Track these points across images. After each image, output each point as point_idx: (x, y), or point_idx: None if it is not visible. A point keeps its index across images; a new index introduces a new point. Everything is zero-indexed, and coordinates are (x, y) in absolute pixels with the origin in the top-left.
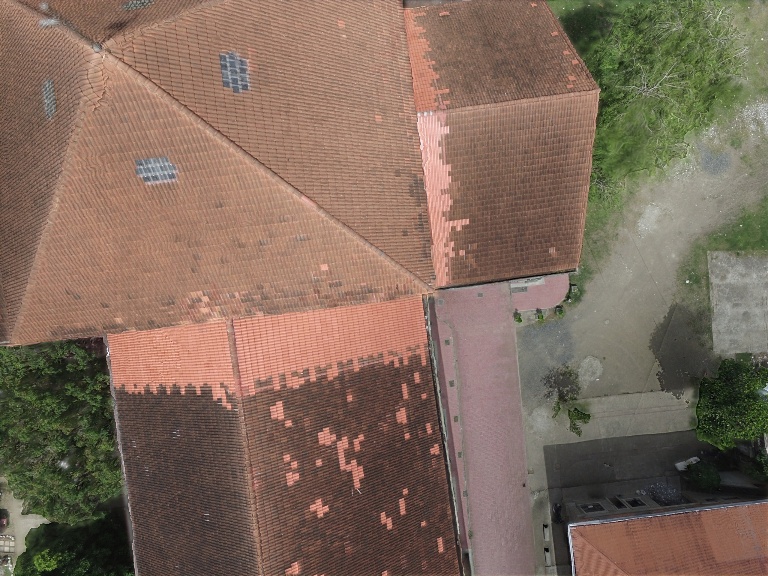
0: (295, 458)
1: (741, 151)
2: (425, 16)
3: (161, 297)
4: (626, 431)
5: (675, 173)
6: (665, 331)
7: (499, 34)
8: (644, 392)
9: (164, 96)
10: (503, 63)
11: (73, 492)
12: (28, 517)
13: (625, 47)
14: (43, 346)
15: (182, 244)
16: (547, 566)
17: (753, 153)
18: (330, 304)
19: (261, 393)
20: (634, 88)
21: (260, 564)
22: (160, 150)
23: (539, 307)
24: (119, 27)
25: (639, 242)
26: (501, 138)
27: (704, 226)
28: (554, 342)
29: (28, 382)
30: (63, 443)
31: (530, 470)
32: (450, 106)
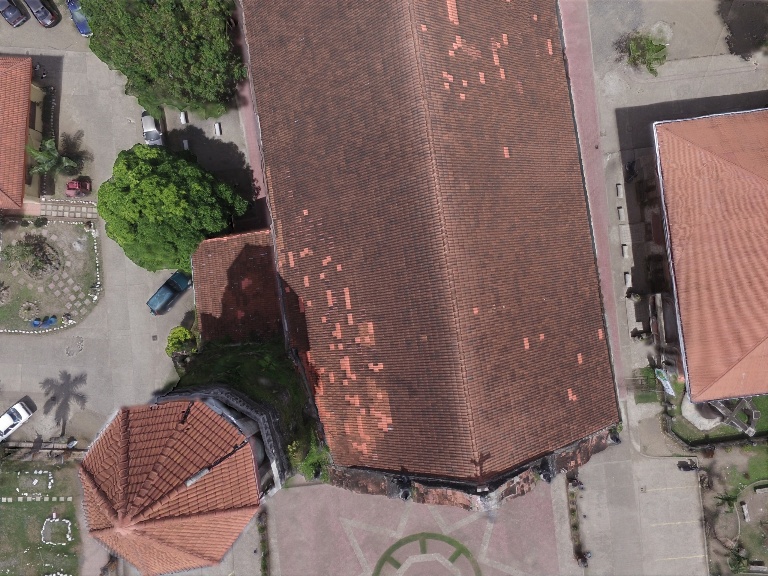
0: None
1: None
2: None
3: None
4: (696, 93)
5: None
6: None
7: None
8: (713, 55)
9: None
10: None
11: (182, 45)
12: None
13: None
14: None
15: None
16: (620, 224)
17: None
18: None
19: None
20: None
21: None
22: None
23: None
24: None
25: None
26: None
27: None
28: (625, 8)
29: None
30: None
31: (603, 132)
32: None
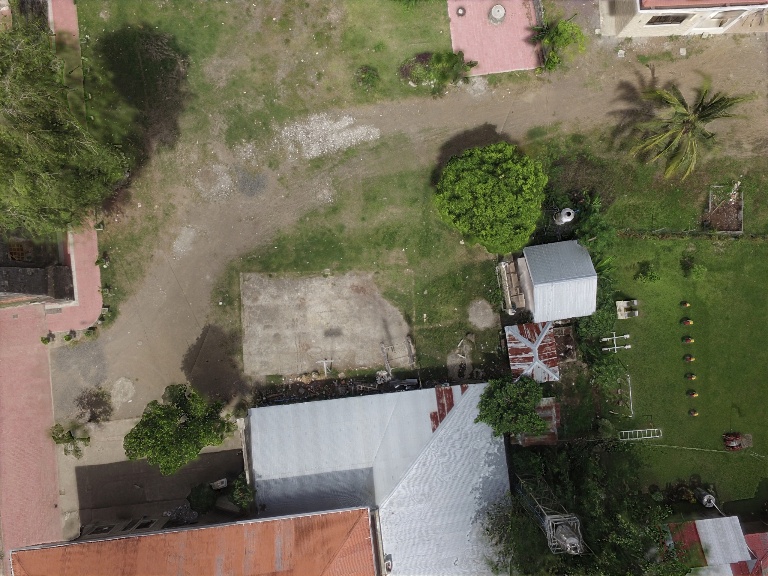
0: None
1: (278, 173)
2: None
3: None
4: None
5: (212, 195)
6: (198, 353)
7: None
8: None
9: None
10: None
11: None
12: None
13: None
14: None
15: None
16: None
17: (290, 175)
18: None
19: None
20: None
21: None
22: None
23: (72, 328)
24: None
25: (174, 264)
26: None
27: (239, 248)
28: (87, 363)
29: None
30: None
31: (62, 491)
32: None
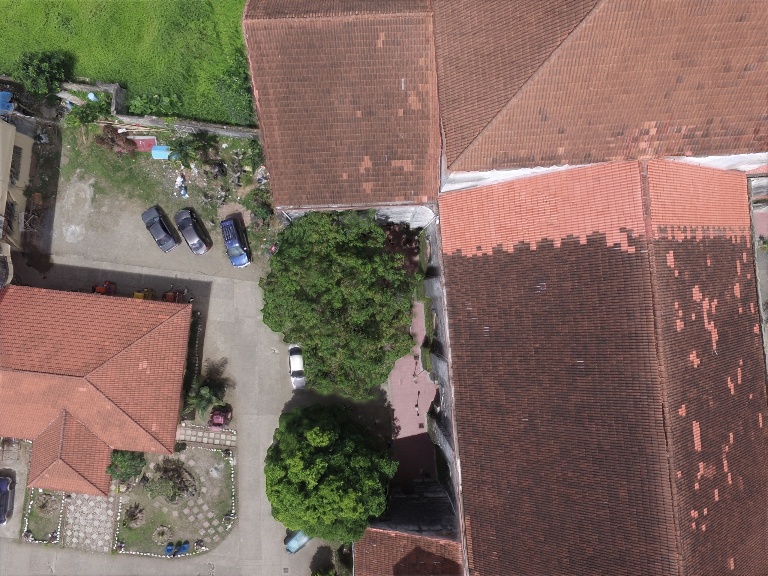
0: (681, 307)
1: None
2: None
3: (616, 126)
4: None
5: None
6: None
7: None
8: None
9: None
10: None
11: (375, 362)
12: (250, 413)
13: None
14: (366, 214)
15: (677, 63)
16: None
17: None
18: (757, 148)
19: (661, 239)
20: None
21: (667, 398)
22: None
23: (762, 234)
24: None
25: None
26: None
27: None
28: None
29: (342, 251)
30: (369, 313)
31: None
32: None
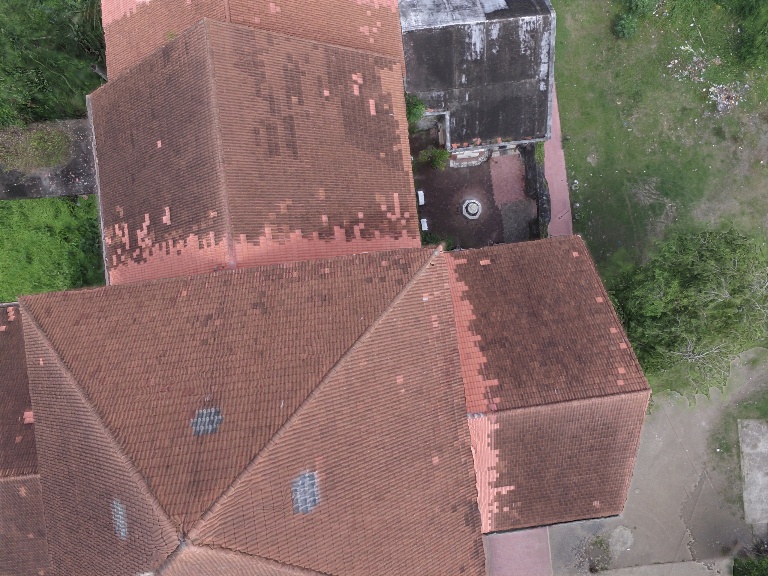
0: None
1: None
2: (466, 263)
3: None
4: None
5: None
6: (696, 500)
7: (543, 296)
8: (675, 562)
9: (239, 553)
10: (550, 343)
11: None
12: None
13: (667, 297)
14: None
15: None
16: None
17: None
18: None
19: None
20: (679, 354)
21: None
22: (230, 574)
23: None
24: (194, 488)
25: (669, 410)
26: (550, 429)
27: (734, 393)
28: None
29: None
30: None
31: None
32: (500, 406)
